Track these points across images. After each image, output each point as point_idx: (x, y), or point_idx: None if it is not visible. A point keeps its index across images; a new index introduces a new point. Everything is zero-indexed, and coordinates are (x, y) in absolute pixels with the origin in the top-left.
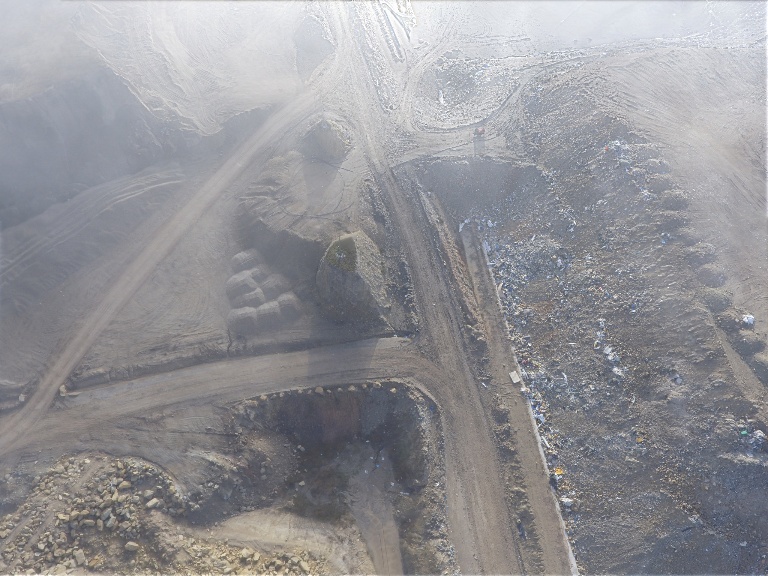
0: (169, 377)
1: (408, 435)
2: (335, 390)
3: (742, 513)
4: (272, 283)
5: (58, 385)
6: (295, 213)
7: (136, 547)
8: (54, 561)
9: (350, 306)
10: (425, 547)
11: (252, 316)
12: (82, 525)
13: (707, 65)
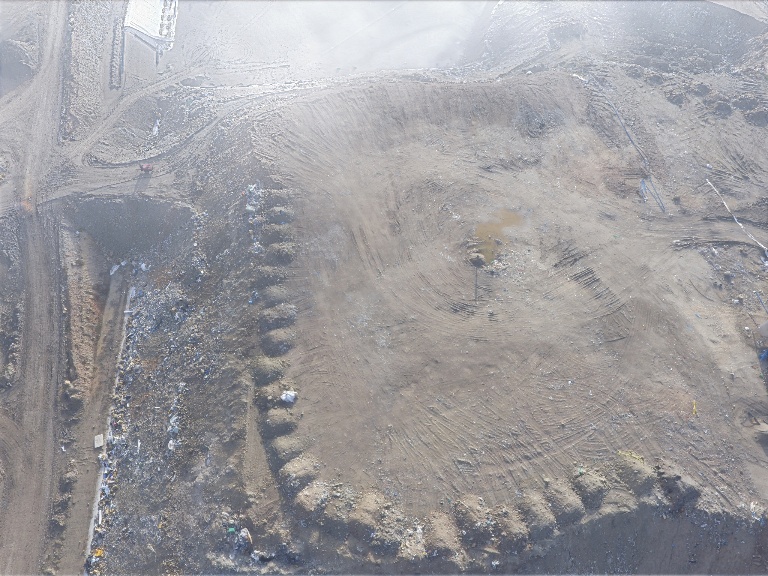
0: None
1: None
2: None
3: None
4: None
5: None
6: None
7: None
8: None
9: None
10: None
11: None
12: None
13: (398, 103)
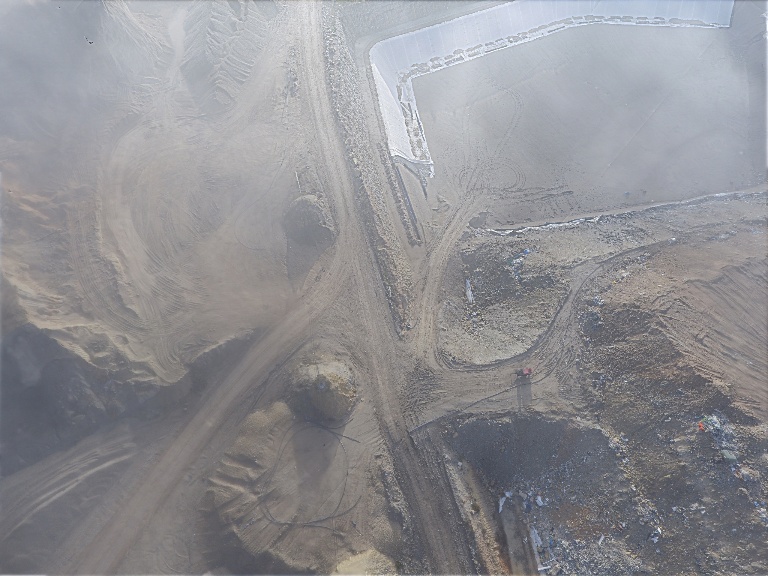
0: None
1: None
2: None
3: None
4: None
5: None
6: (281, 520)
7: None
8: None
9: None
10: None
11: None
12: None
13: None
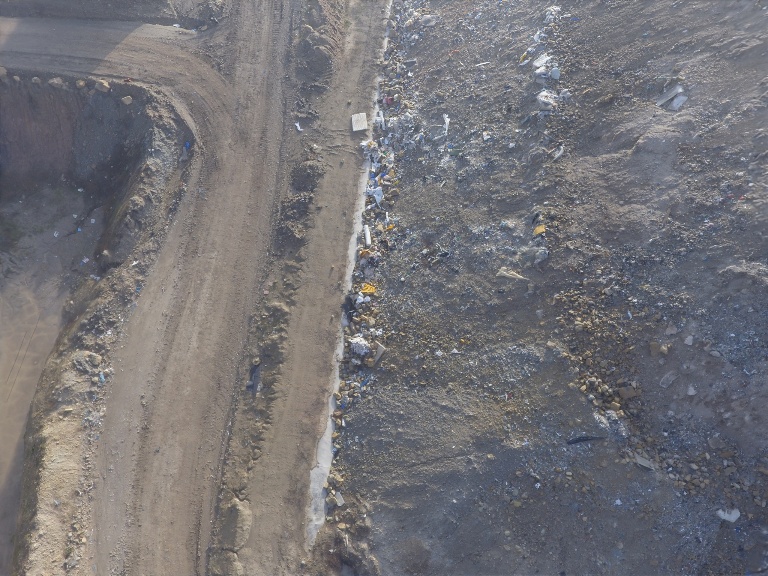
0: None
1: (129, 179)
2: (28, 79)
3: (749, 435)
4: None
5: None
6: None
7: None
8: None
9: None
10: (62, 359)
11: None
12: None
13: None
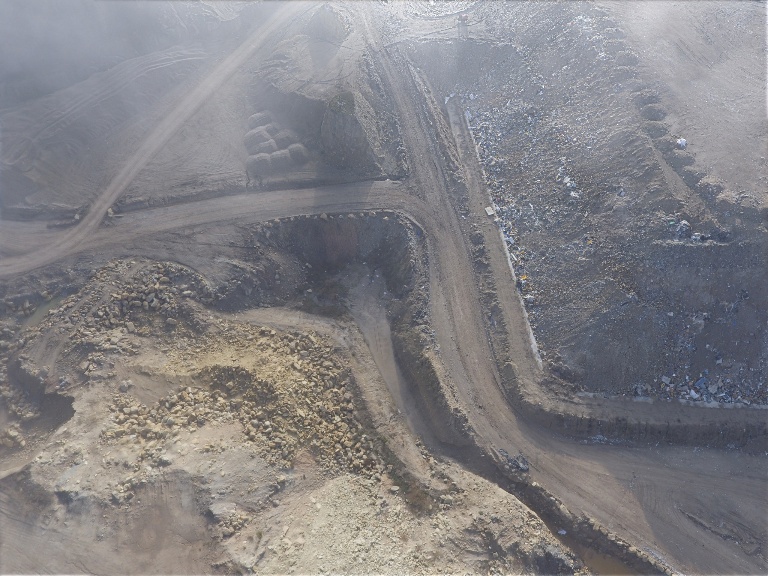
0: (198, 205)
1: (398, 253)
2: (337, 217)
3: (670, 290)
4: (283, 135)
5: (106, 208)
6: (302, 79)
7: (175, 322)
8: (110, 327)
9: (349, 152)
10: (411, 331)
11: (267, 159)
12: (131, 305)
13: None
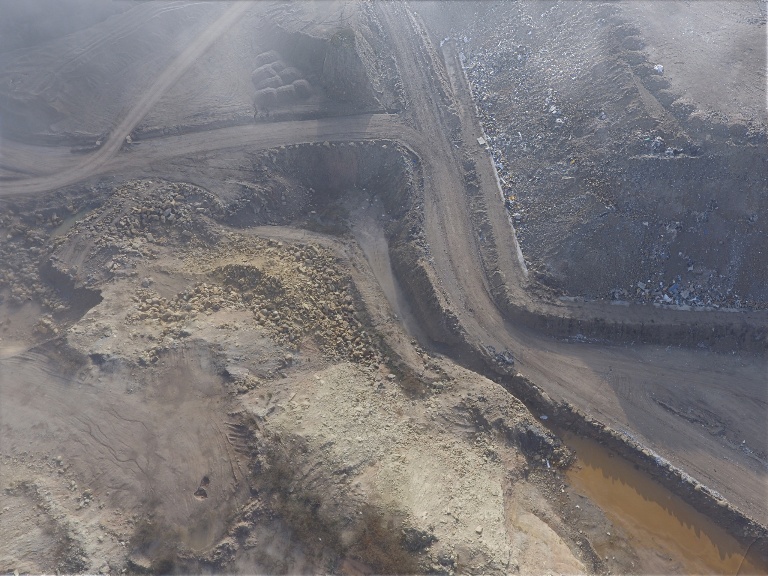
0: (209, 133)
1: (396, 178)
2: (339, 145)
3: (645, 201)
4: (288, 71)
5: (125, 136)
6: (306, 20)
7: (190, 234)
8: (131, 236)
9: (350, 87)
10: (407, 245)
11: (273, 92)
12: (150, 219)
13: None
